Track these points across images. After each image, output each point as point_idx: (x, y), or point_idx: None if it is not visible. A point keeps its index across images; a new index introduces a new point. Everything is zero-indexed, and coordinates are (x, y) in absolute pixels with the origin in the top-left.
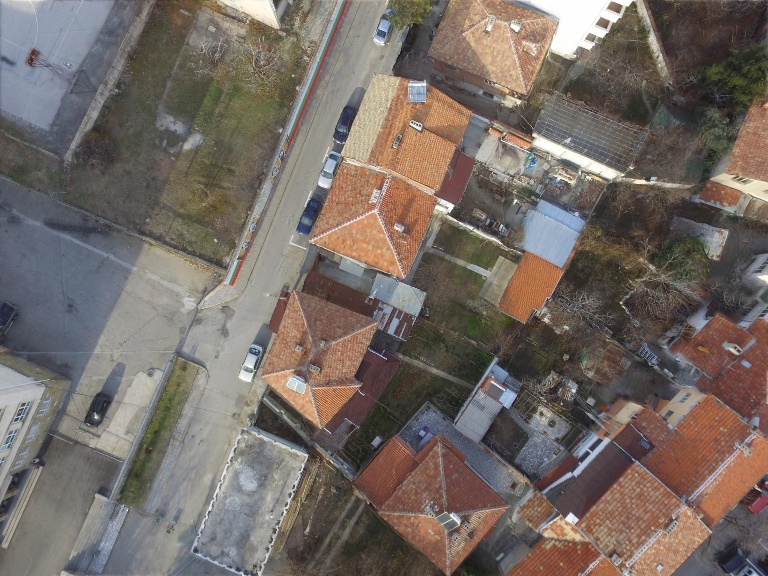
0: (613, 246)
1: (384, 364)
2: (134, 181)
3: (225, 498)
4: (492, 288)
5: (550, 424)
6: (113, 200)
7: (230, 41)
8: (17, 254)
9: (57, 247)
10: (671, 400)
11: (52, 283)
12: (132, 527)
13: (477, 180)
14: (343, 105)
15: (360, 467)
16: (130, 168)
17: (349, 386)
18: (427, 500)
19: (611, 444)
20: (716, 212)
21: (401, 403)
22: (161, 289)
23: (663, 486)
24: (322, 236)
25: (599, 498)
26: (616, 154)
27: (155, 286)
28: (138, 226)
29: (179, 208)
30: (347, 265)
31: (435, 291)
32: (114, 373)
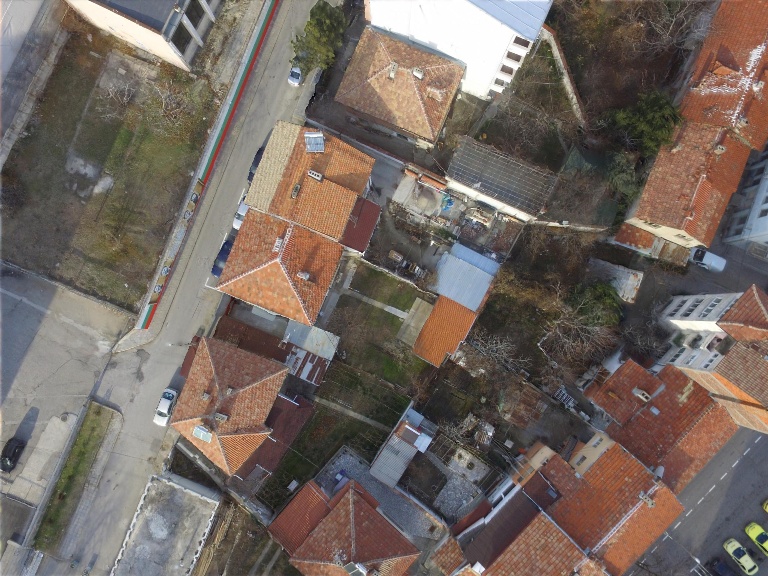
0: (526, 290)
1: (296, 410)
2: (44, 225)
3: (135, 546)
4: (409, 330)
5: (468, 466)
6: (22, 245)
7: (141, 83)
8: None
9: None
10: (586, 443)
11: None
12: (47, 573)
13: (394, 221)
14: (258, 146)
15: (274, 512)
16: (39, 212)
17: (258, 433)
18: (336, 548)
19: (520, 491)
20: (633, 253)
21: (318, 446)
22: (75, 333)
23: (566, 537)
24: (227, 284)
25: (507, 546)
26: (526, 199)
27: (69, 330)
28: (48, 271)
29: (89, 253)
30: (259, 309)
31: (351, 334)
32: (27, 418)
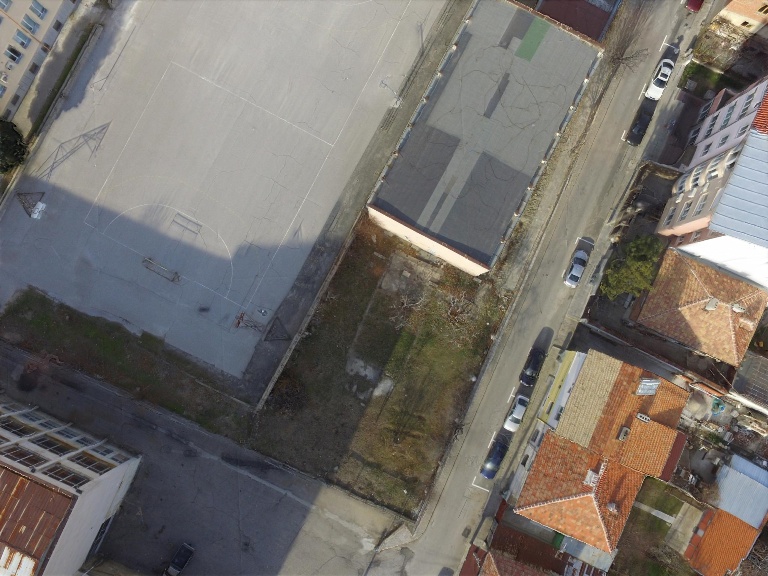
0: None
1: None
2: (323, 428)
3: None
4: (677, 535)
5: None
6: (301, 447)
7: (424, 286)
8: (193, 489)
9: (234, 483)
10: None
11: (228, 520)
12: None
13: None
14: (530, 345)
15: None
16: (319, 414)
17: None
18: None
19: None
20: None
21: None
22: (340, 529)
23: None
24: (528, 508)
25: None
26: None
27: (334, 526)
28: (325, 473)
29: (368, 457)
30: None
31: None
32: None
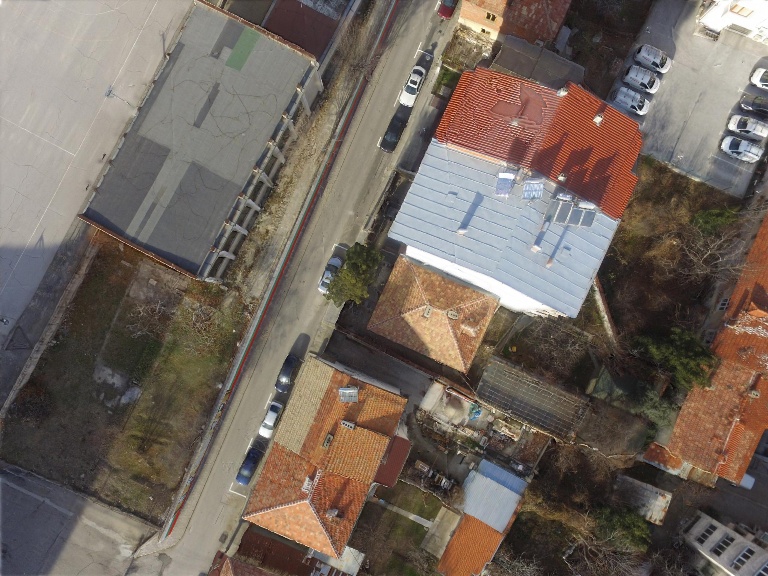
0: (554, 514)
1: None
2: (70, 435)
3: None
4: (434, 539)
5: None
6: (48, 455)
7: (171, 293)
8: None
9: None
10: None
11: None
12: None
13: (421, 429)
14: (286, 351)
15: None
16: (66, 422)
17: None
18: None
19: None
20: None
21: None
22: (97, 536)
23: None
24: (255, 515)
25: None
26: (557, 428)
27: (91, 532)
28: (73, 481)
29: (115, 464)
30: None
31: (375, 544)
32: None
